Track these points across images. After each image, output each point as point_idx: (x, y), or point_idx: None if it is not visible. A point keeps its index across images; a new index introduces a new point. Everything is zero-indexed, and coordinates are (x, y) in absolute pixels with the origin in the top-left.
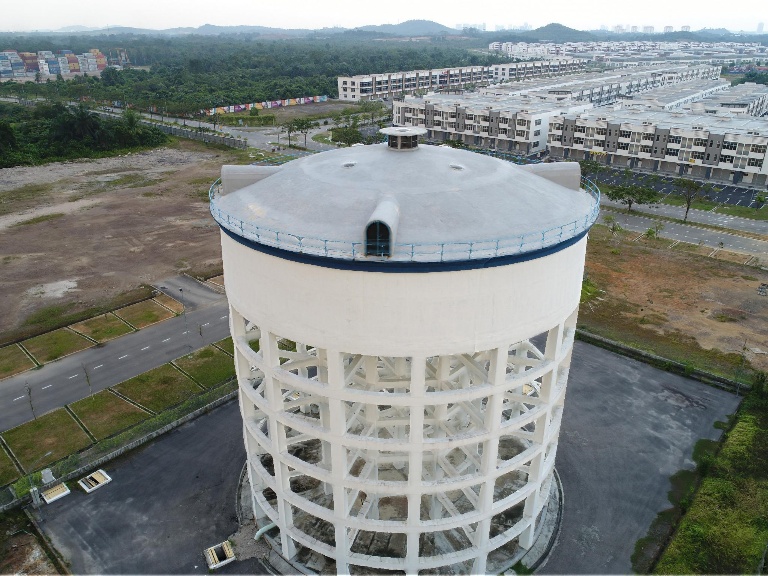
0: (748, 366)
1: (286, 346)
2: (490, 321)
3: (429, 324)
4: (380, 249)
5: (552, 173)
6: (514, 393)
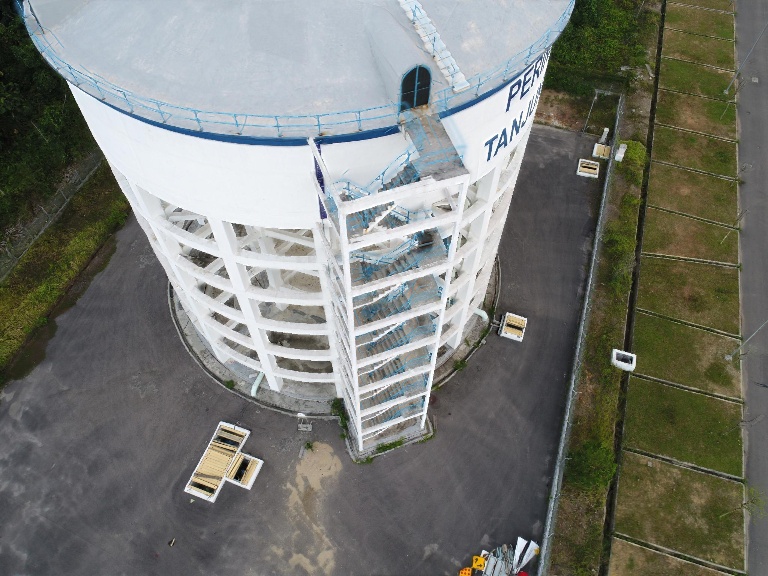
0: None
1: (635, 449)
2: None
3: None
4: None
5: None
6: None
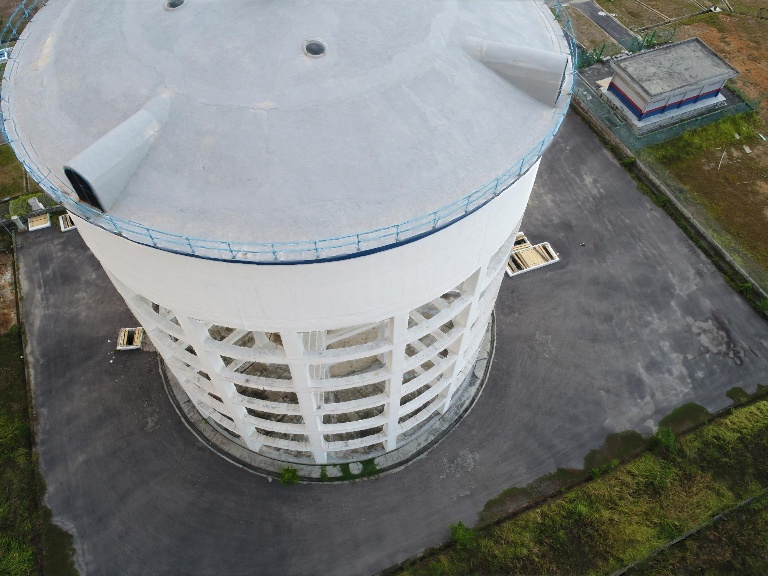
0: None
1: None
2: (259, 309)
3: (178, 291)
4: (90, 200)
5: (512, 69)
6: (418, 314)
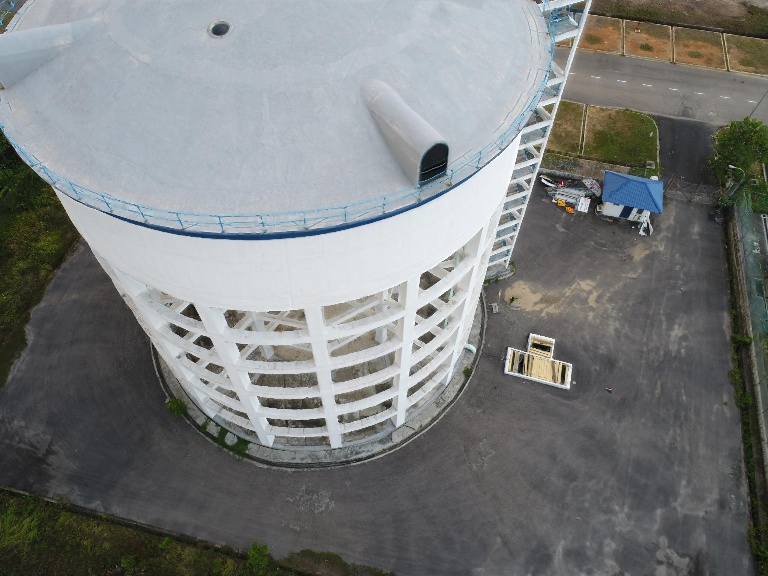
0: None
1: None
2: None
3: None
4: None
5: (388, 129)
6: None
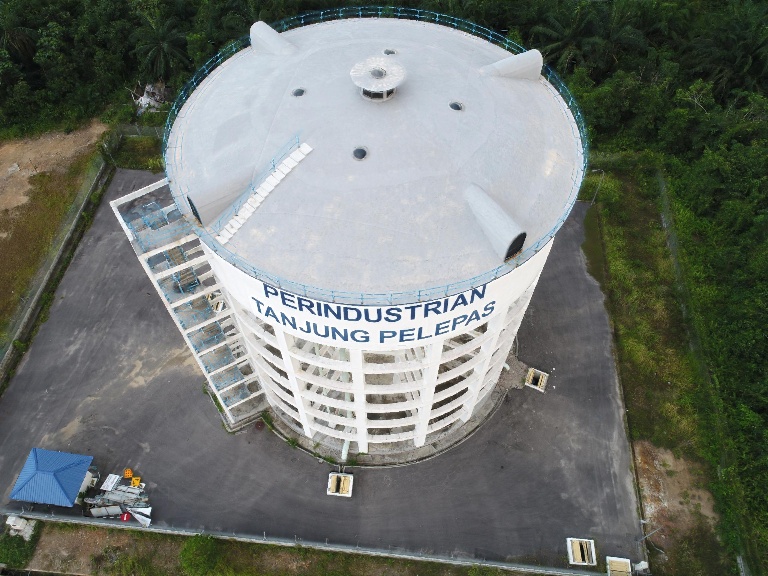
0: (52, 172)
1: None
2: None
3: None
4: None
5: None
6: None
